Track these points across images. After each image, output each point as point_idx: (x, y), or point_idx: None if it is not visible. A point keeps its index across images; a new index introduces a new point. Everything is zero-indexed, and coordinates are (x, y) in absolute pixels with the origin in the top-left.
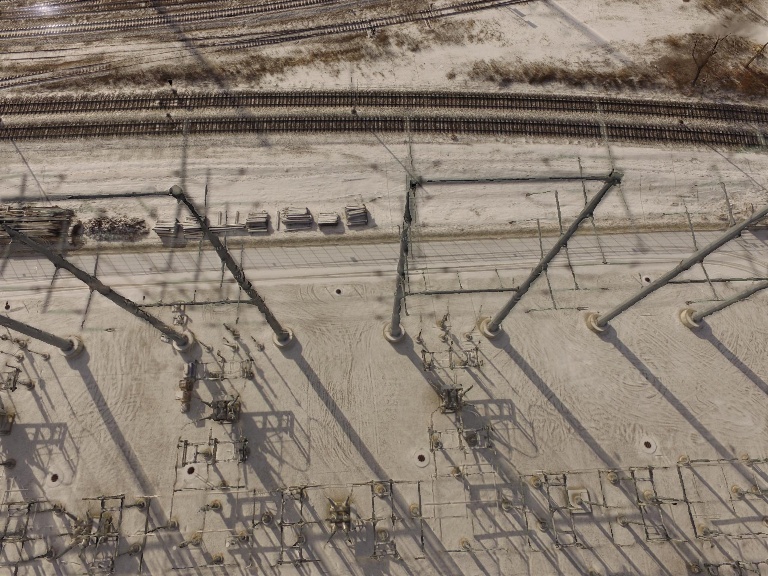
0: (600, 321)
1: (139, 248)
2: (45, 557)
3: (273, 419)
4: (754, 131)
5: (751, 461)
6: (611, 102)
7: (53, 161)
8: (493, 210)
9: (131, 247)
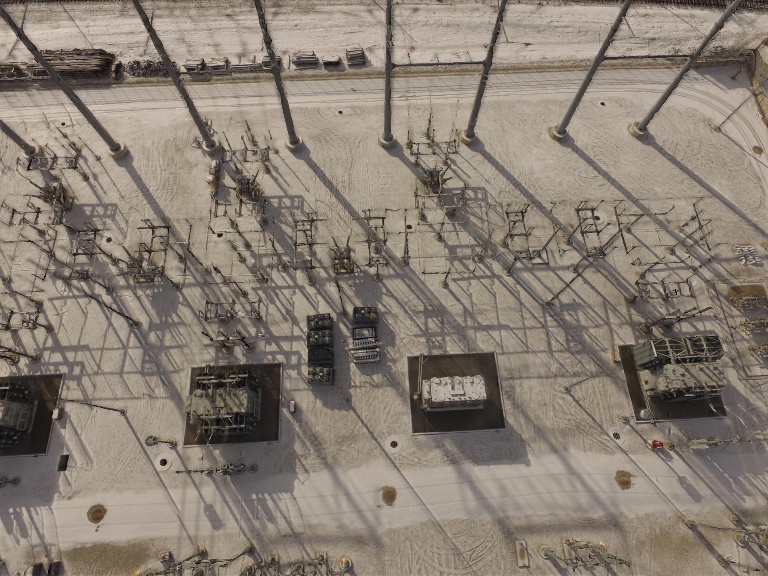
0: (560, 127)
1: (172, 82)
2: (104, 292)
3: (287, 201)
4: None
5: (682, 227)
6: None
7: (96, 19)
8: (472, 54)
9: (165, 81)
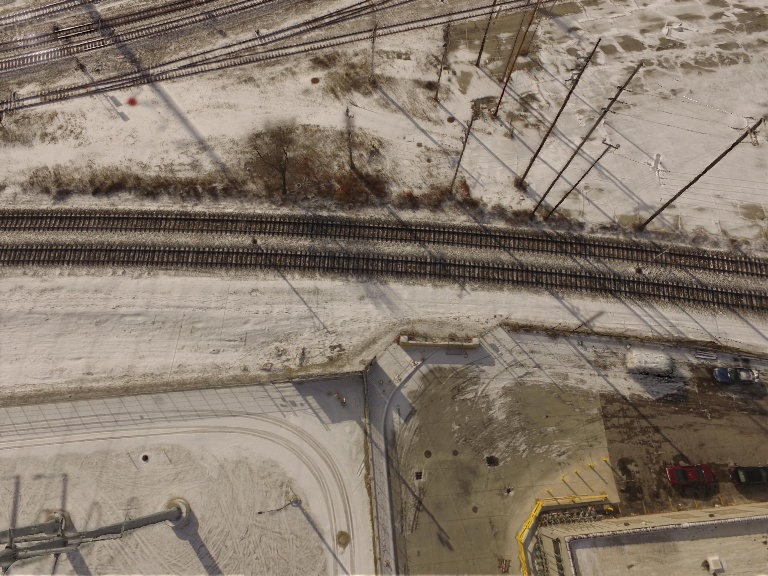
0: None
1: None
2: None
3: None
4: (338, 250)
5: None
6: (180, 217)
7: None
8: None
9: None
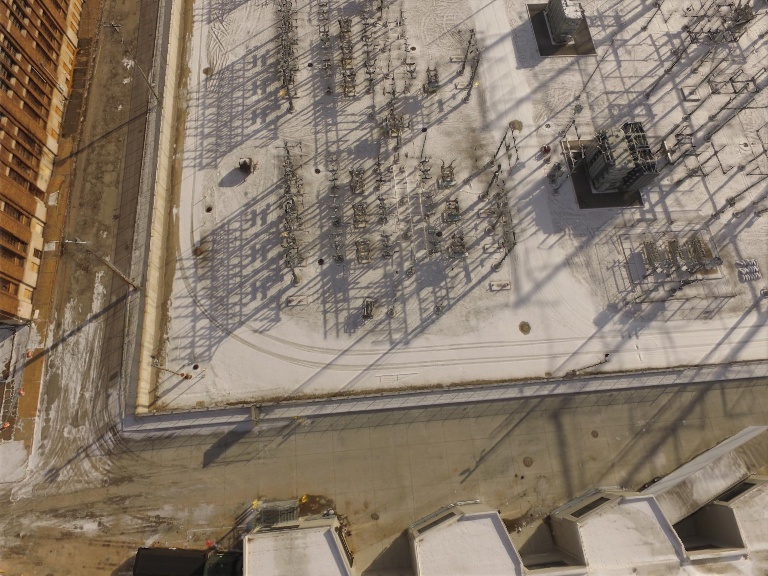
0: None
1: None
2: None
3: None
4: None
5: (762, 211)
6: None
7: None
8: None
9: None
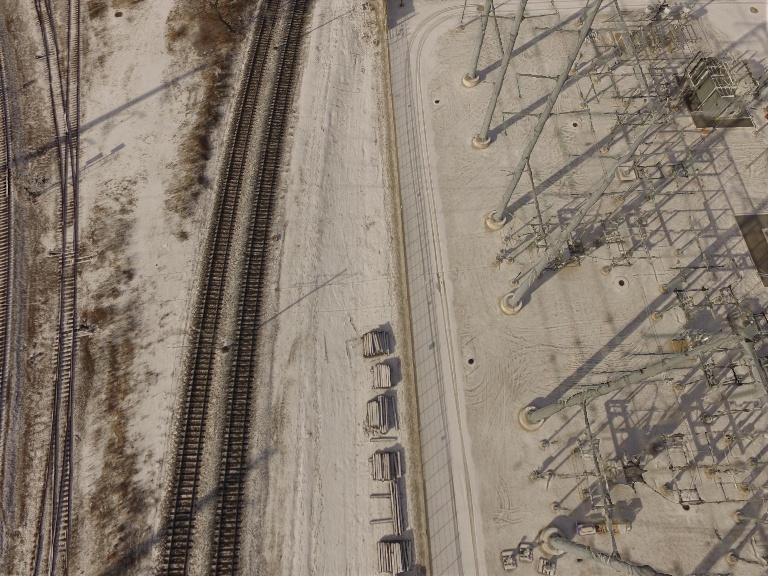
0: (486, 136)
1: None
2: None
3: (616, 422)
4: (290, 4)
5: None
6: (245, 95)
7: None
8: (368, 209)
9: None
